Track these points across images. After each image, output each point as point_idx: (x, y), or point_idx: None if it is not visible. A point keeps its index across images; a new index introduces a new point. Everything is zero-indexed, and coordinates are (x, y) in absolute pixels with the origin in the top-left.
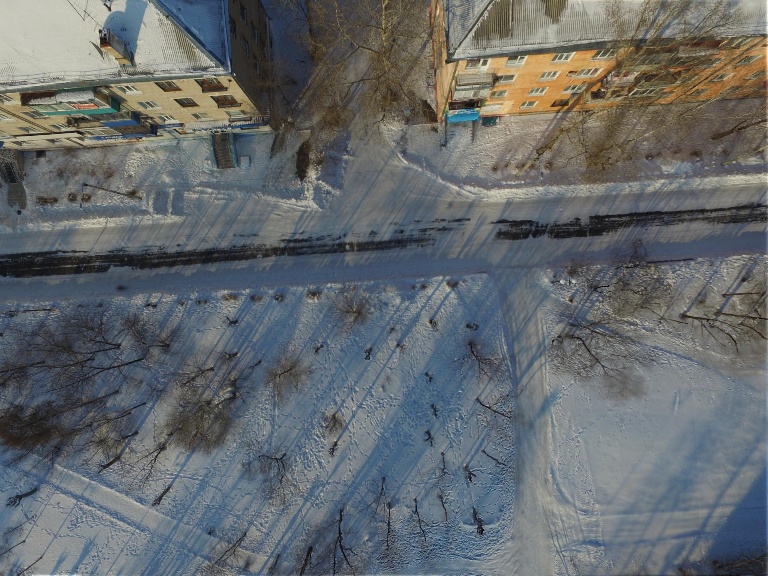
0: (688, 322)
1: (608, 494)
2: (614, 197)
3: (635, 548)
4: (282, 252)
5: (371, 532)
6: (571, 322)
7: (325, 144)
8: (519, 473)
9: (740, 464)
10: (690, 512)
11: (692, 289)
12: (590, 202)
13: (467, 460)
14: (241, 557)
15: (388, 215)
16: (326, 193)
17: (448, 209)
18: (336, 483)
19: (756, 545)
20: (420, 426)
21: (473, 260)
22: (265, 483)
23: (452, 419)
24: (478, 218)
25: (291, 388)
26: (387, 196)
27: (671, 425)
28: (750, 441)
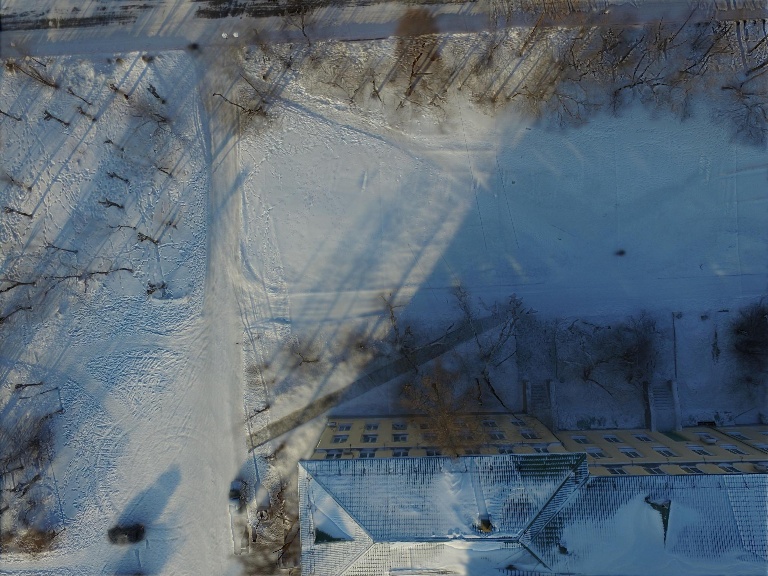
0: (379, 101)
1: (296, 272)
2: None
3: (321, 326)
4: None
5: (62, 304)
6: (264, 100)
7: None
8: (210, 250)
9: (424, 243)
10: (375, 291)
11: (383, 68)
12: None
13: (158, 235)
14: None
15: None
16: None
17: None
18: (30, 255)
19: (438, 325)
20: (114, 201)
21: (172, 38)
22: None
23: (145, 194)
24: None
25: None
26: None
27: (358, 203)
28: (435, 221)
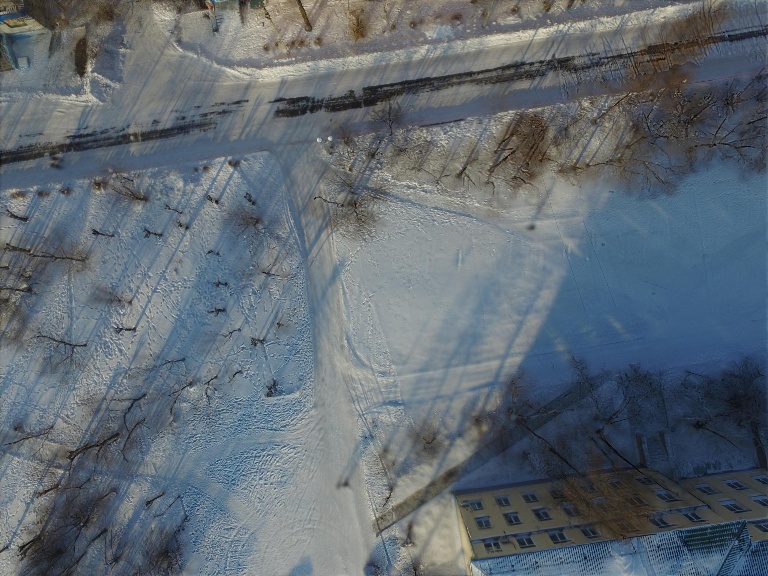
0: None
1: (403, 354)
2: (384, 67)
3: (433, 404)
4: (68, 148)
5: (176, 413)
6: (353, 191)
7: (101, 39)
8: (316, 342)
9: (525, 312)
10: (482, 364)
11: (465, 148)
12: (362, 74)
13: (263, 334)
14: (50, 450)
15: (168, 103)
16: (105, 86)
17: (226, 92)
18: (138, 368)
19: (547, 389)
20: (215, 305)
21: (255, 140)
22: (68, 375)
23: (245, 295)
24: (256, 98)
25: (85, 279)
26: (166, 85)
27: (456, 281)
28: (533, 289)
